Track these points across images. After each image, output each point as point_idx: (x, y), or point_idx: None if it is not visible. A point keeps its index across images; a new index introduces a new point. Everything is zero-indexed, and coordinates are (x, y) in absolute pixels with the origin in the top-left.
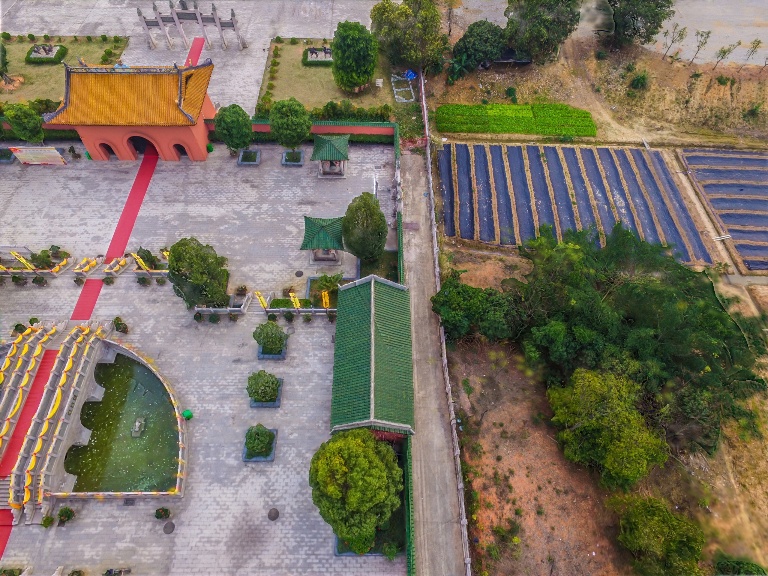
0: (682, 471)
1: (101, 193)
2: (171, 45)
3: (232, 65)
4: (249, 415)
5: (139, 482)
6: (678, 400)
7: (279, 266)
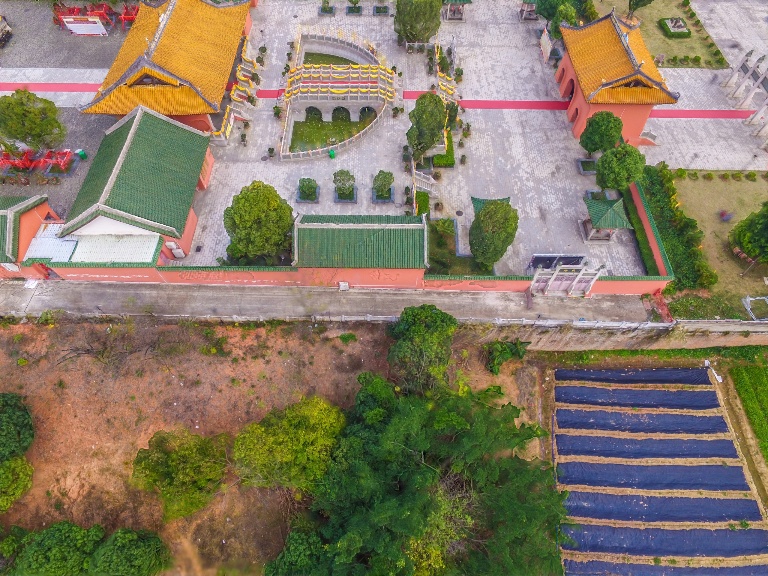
0: (258, 568)
1: (521, 86)
2: (734, 96)
3: (728, 144)
4: (331, 187)
5: (299, 149)
6: (305, 527)
7: (466, 199)
